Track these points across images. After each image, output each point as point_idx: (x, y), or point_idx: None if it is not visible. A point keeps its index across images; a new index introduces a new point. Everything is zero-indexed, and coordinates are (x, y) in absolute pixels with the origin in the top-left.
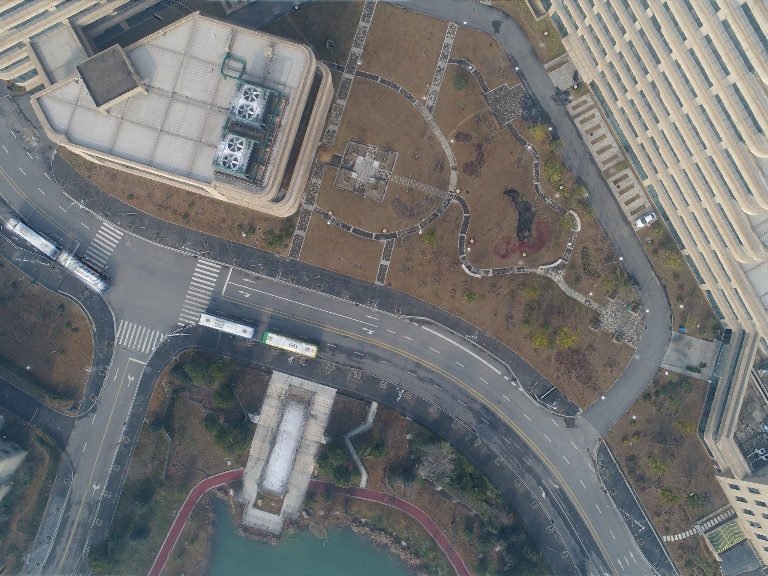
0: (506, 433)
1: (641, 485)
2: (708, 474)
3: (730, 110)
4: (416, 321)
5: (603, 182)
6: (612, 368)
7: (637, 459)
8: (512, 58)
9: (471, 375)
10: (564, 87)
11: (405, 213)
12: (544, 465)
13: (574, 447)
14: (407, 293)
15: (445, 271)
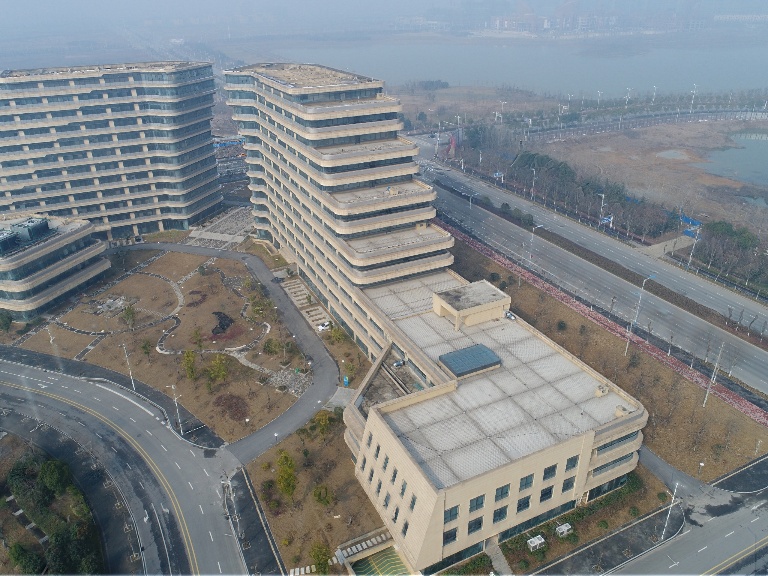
0: (132, 460)
1: (272, 505)
2: (360, 495)
3: (310, 174)
4: (93, 381)
5: (297, 312)
6: (270, 410)
7: (276, 483)
8: (249, 268)
9: (122, 416)
10: (282, 277)
11: (126, 322)
12: (161, 489)
13: (206, 474)
14: (97, 365)
15: (139, 350)
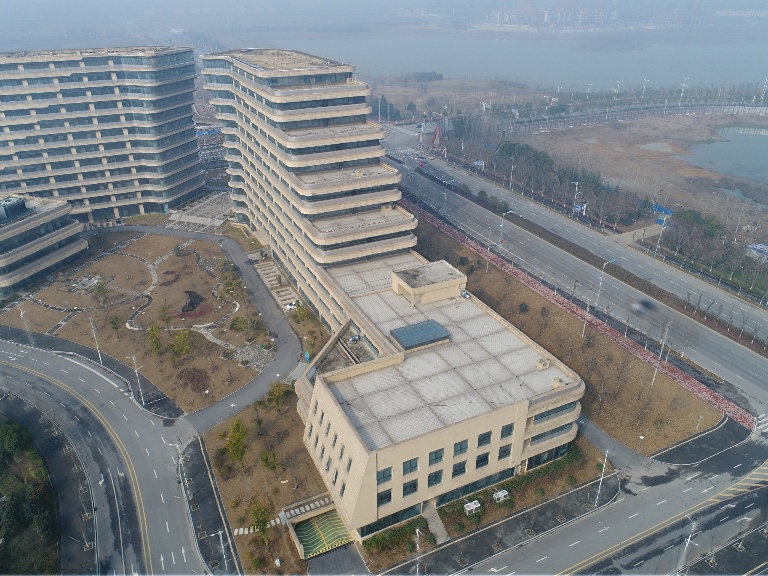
0: (93, 428)
1: (223, 471)
2: (308, 462)
3: (278, 156)
4: (62, 355)
5: (267, 292)
6: (231, 383)
7: None
8: (225, 250)
9: (87, 387)
10: (256, 259)
11: None
12: (119, 455)
13: (163, 442)
14: (68, 340)
15: (109, 326)
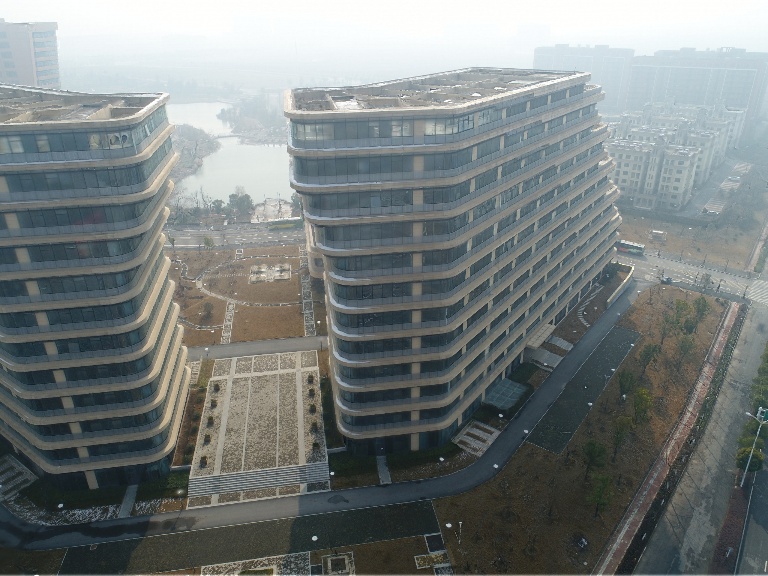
0: None
1: None
2: None
3: None
4: None
5: None
6: None
7: None
8: None
9: None
10: None
11: None
12: None
13: None
14: None
15: None
